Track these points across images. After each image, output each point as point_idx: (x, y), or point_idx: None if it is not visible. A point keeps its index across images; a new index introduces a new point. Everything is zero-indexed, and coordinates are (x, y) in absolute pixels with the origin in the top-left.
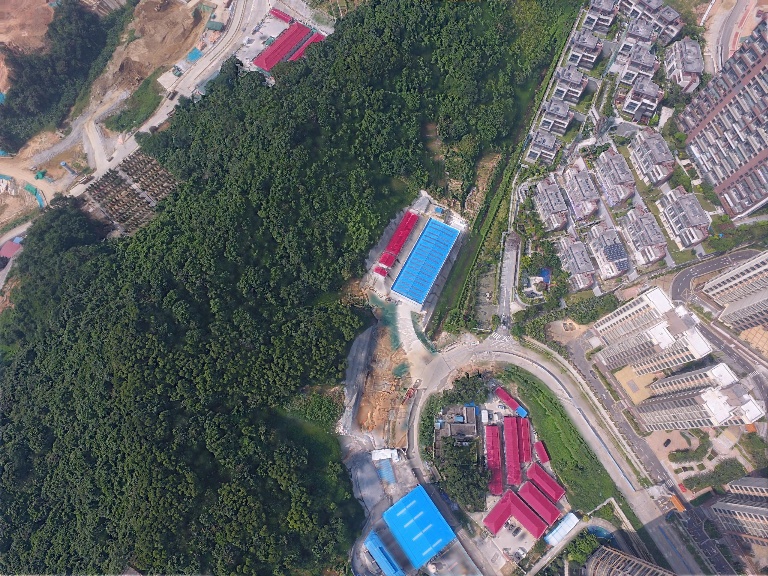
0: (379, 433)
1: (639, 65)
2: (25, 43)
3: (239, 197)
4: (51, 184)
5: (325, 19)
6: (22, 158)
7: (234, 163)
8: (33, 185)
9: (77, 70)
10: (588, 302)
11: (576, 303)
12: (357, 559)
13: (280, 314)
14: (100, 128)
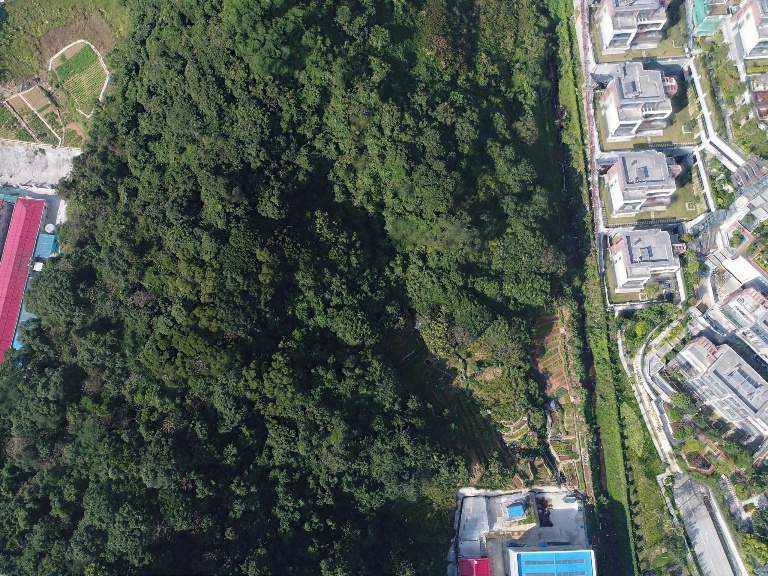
0: None
1: None
2: None
3: None
4: None
5: (20, 156)
6: None
7: None
8: None
9: None
10: None
11: None
12: None
13: None
14: None
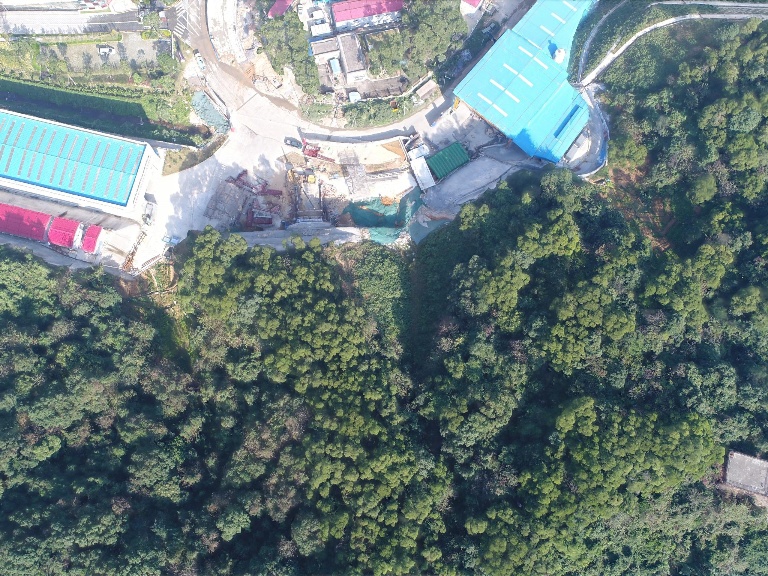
0: (390, 186)
1: None
2: None
3: None
4: None
5: None
6: None
7: None
8: None
9: None
10: None
11: None
12: (580, 170)
13: (222, 394)
14: None
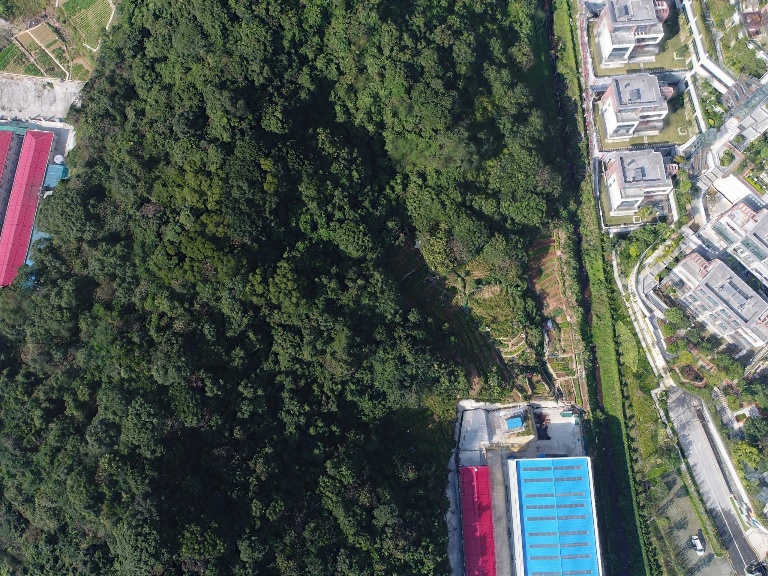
0: None
1: None
2: None
3: None
4: None
5: (29, 91)
6: None
7: None
8: None
9: None
10: None
11: None
12: None
13: None
14: None
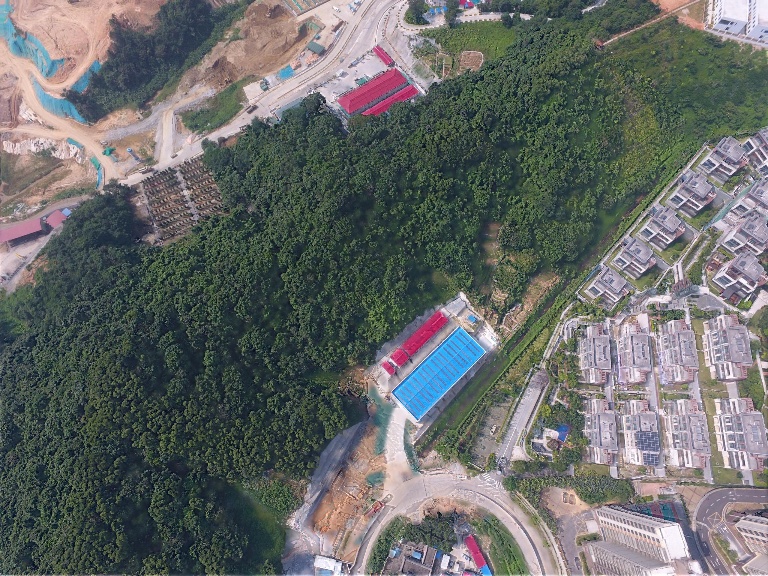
0: (331, 538)
1: (749, 236)
2: (135, 18)
3: (268, 254)
4: (114, 164)
5: (425, 73)
6: (98, 129)
7: (280, 208)
8: (98, 160)
9: (174, 56)
10: (599, 480)
11: (586, 476)
12: None
13: (270, 384)
14: (176, 120)
